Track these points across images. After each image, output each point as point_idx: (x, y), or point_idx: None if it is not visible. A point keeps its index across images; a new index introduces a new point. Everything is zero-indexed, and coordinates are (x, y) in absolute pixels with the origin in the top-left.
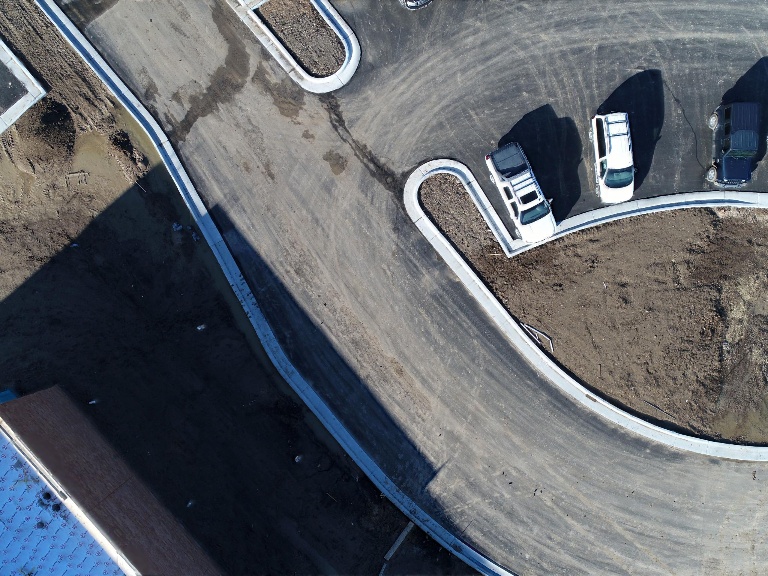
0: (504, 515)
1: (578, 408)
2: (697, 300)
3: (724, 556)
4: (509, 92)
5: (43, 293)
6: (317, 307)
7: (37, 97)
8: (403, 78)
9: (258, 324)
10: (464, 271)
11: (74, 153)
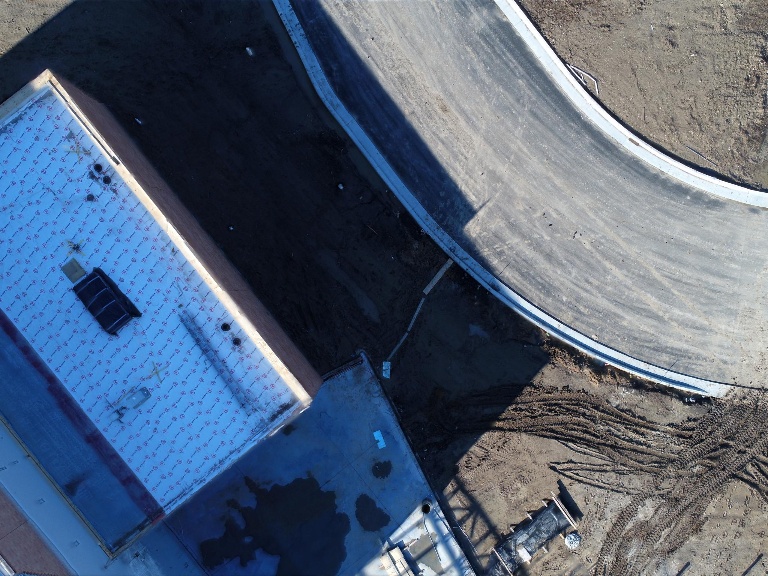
0: (543, 257)
1: (620, 152)
2: (743, 46)
3: (760, 306)
4: None
5: (92, 13)
6: (364, 41)
7: None
8: None
9: (305, 55)
10: (512, 10)
11: None
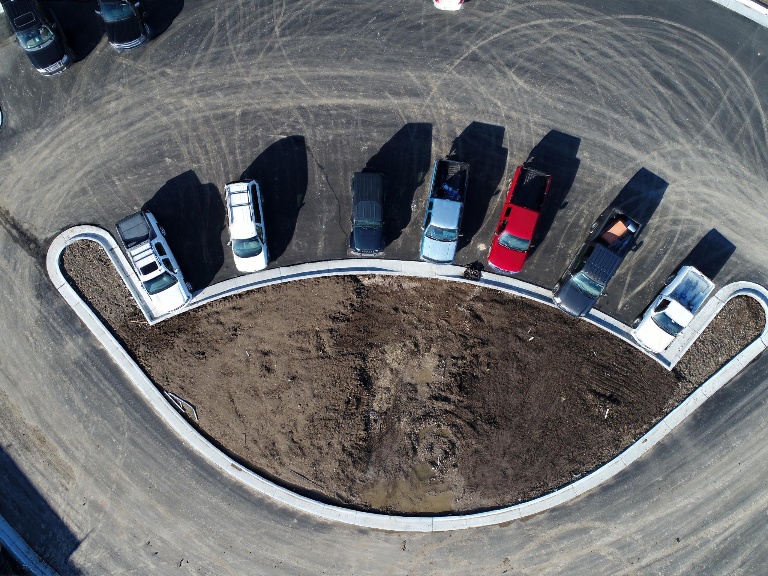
0: None
1: (224, 477)
2: (342, 369)
3: None
4: (152, 158)
5: None
6: None
7: None
8: (45, 143)
9: None
10: (107, 338)
11: None
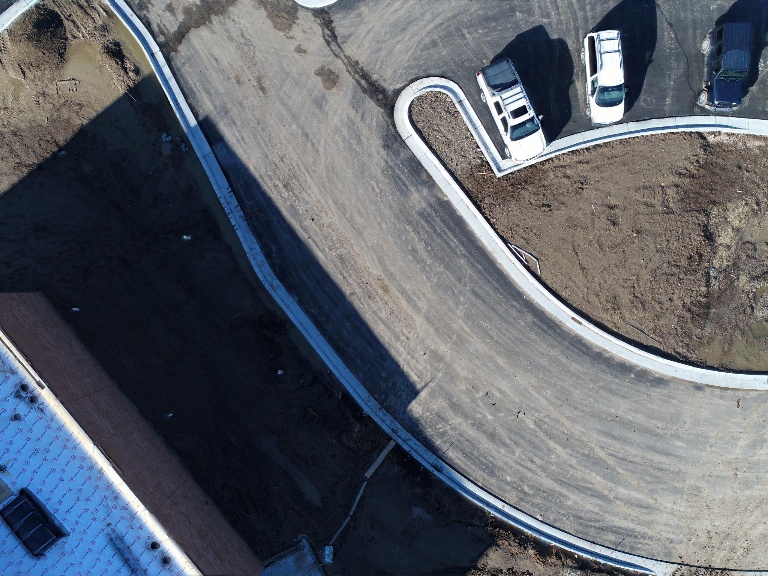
0: (486, 436)
1: (563, 331)
2: (685, 225)
3: (706, 484)
4: (502, 12)
5: (30, 199)
6: (304, 222)
7: (30, 3)
8: None
9: (245, 237)
10: (453, 190)
11: (65, 60)
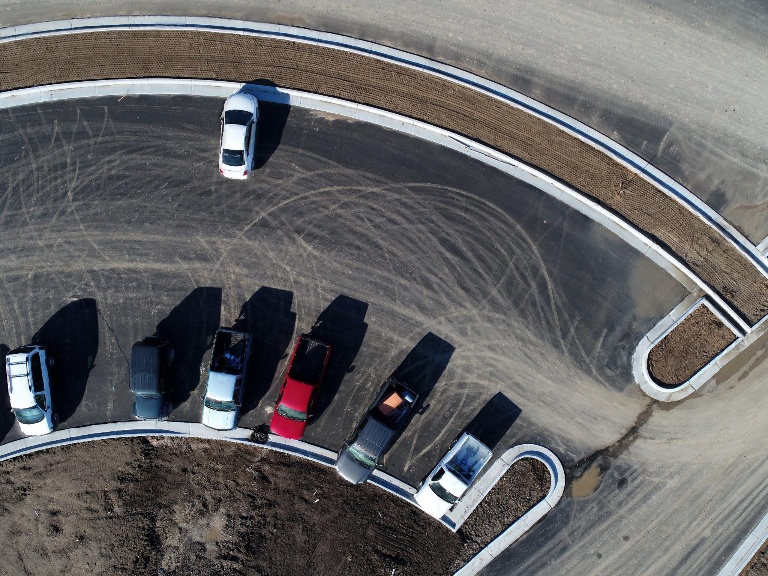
0: None
1: None
2: (130, 528)
3: None
4: None
5: None
6: None
7: None
8: None
9: None
10: None
11: None
